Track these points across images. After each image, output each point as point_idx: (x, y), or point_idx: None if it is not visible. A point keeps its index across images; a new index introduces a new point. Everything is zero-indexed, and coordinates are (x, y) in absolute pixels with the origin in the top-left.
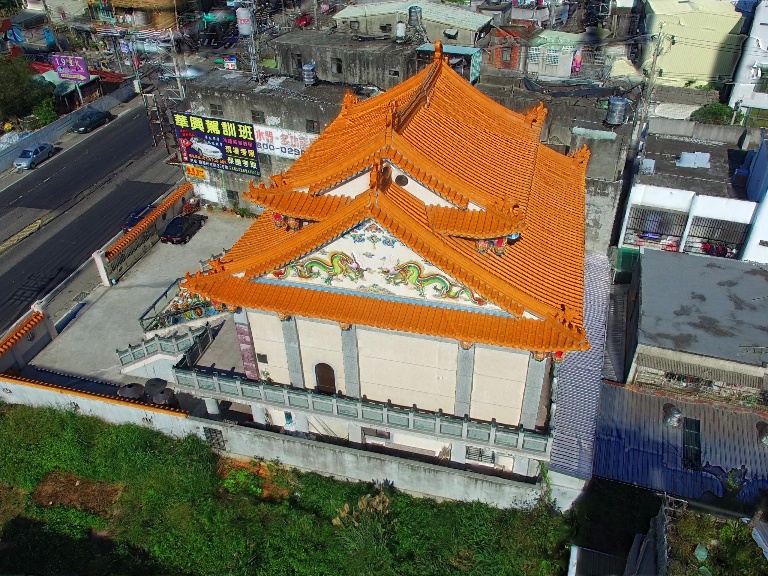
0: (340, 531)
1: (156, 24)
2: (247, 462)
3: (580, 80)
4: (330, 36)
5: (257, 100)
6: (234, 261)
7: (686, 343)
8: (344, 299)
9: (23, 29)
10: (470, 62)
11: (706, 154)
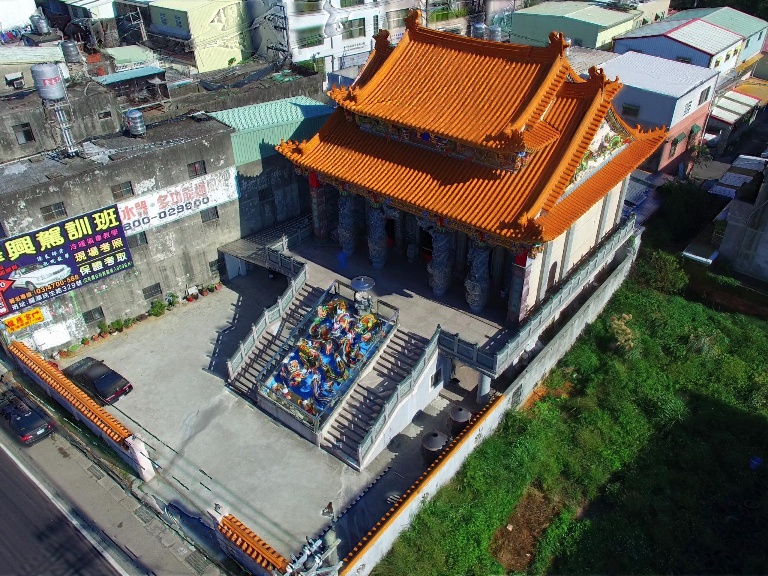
0: (630, 351)
1: None
2: (529, 399)
3: (227, 72)
4: None
5: (119, 170)
6: (532, 207)
7: None
8: (584, 188)
9: None
10: (165, 79)
11: None
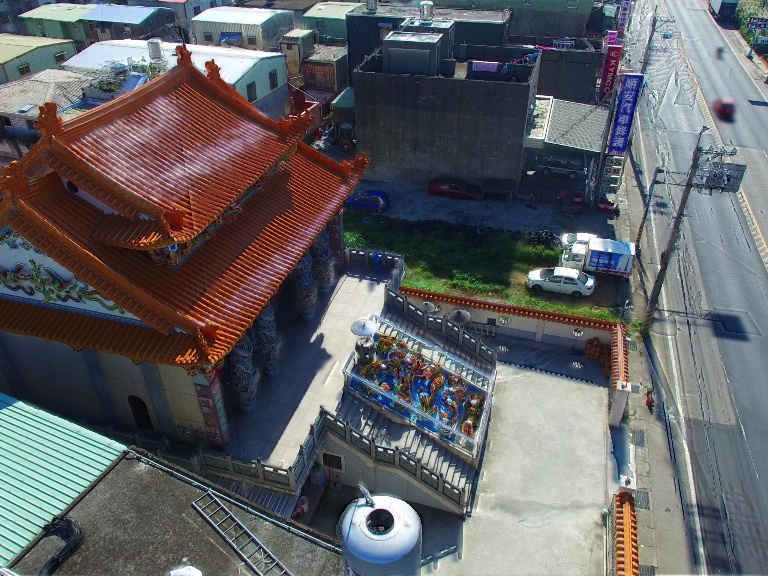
0: None
1: None
2: None
3: None
4: None
5: None
6: None
7: None
8: None
9: None
10: None
11: None
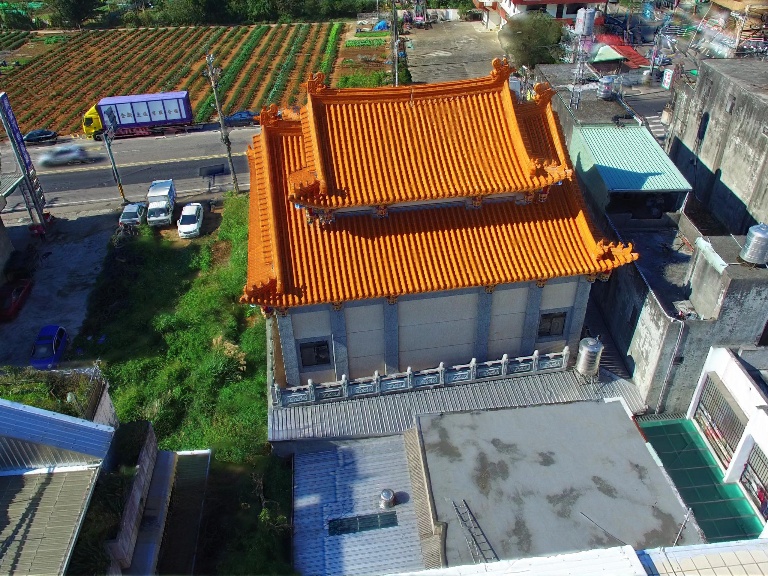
0: None
1: (684, 23)
2: None
3: None
4: (767, 73)
5: None
6: None
7: (442, 452)
8: None
9: (618, 5)
10: None
11: None
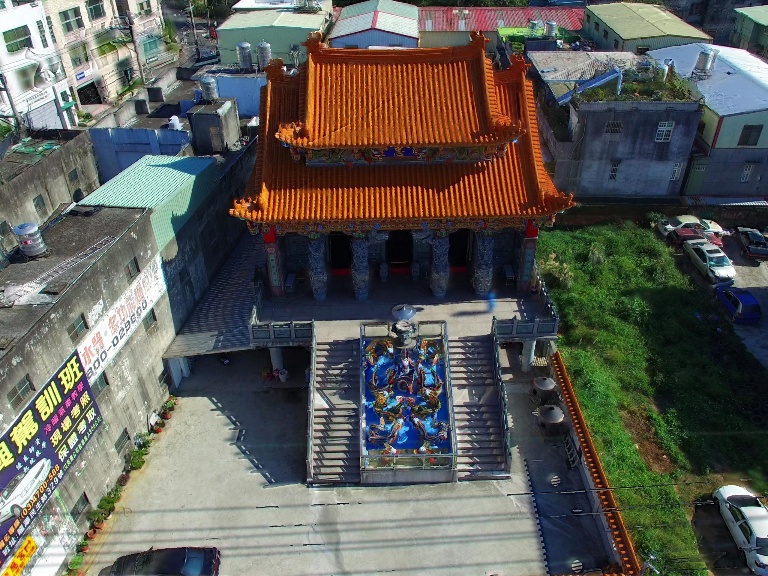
0: None
1: None
2: None
3: None
4: None
5: (71, 303)
6: None
7: None
8: None
9: None
10: None
11: (175, 116)
